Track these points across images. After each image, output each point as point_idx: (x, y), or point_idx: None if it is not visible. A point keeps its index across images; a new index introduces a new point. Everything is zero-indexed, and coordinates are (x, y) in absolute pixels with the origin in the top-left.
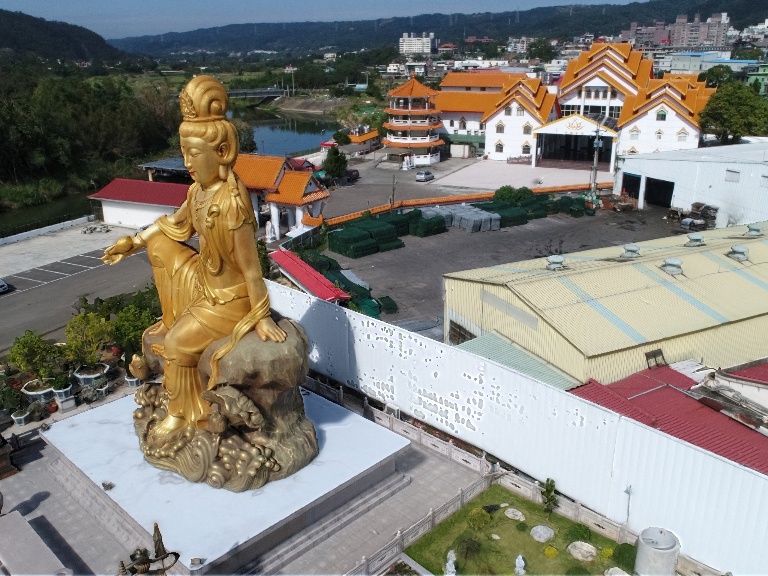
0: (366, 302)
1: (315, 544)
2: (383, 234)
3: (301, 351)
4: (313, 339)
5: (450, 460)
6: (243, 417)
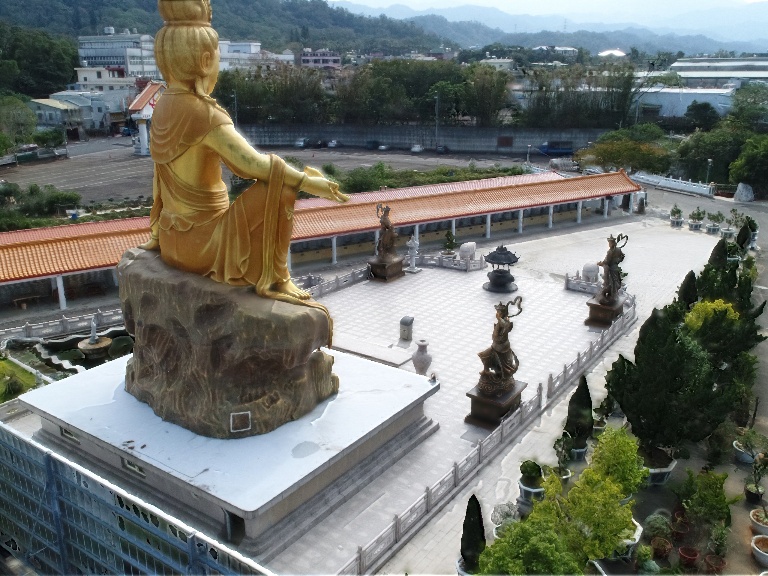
0: None
1: None
2: None
3: None
4: None
5: None
6: None
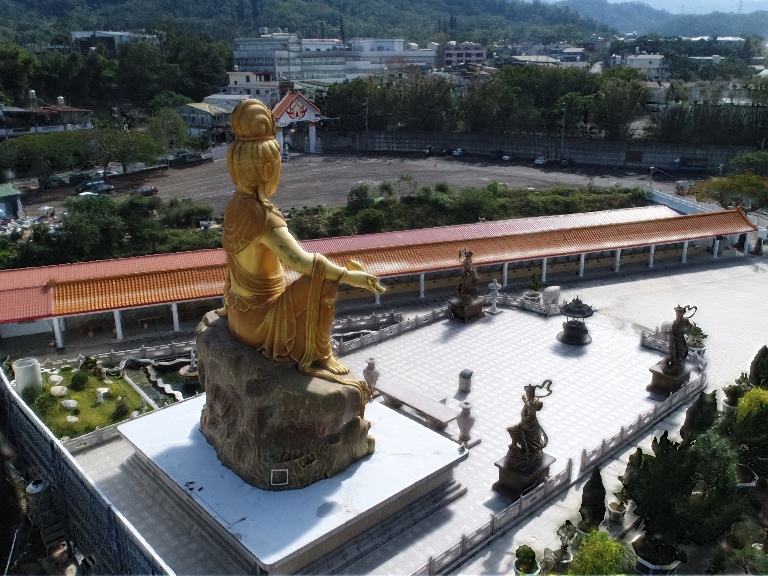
0: None
1: None
2: None
3: None
4: None
5: None
6: None
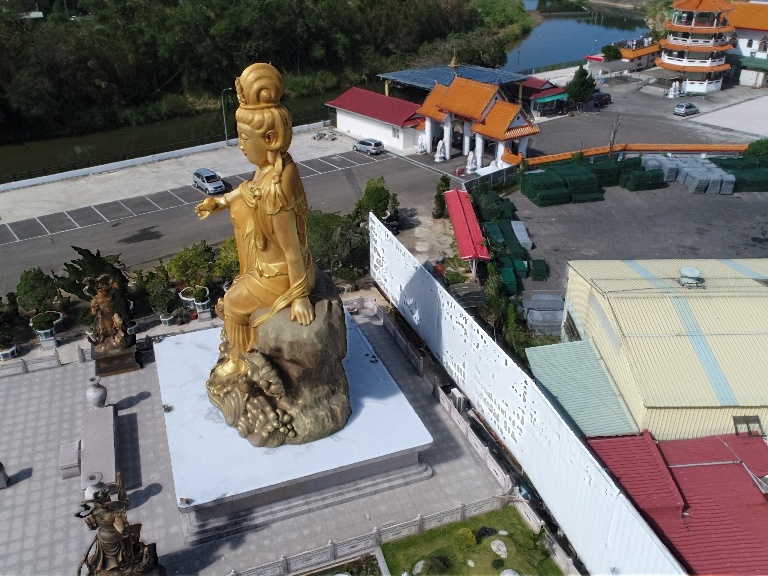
0: (516, 263)
1: (311, 510)
2: (581, 183)
3: (322, 337)
4: (416, 303)
5: (484, 465)
6: (262, 385)
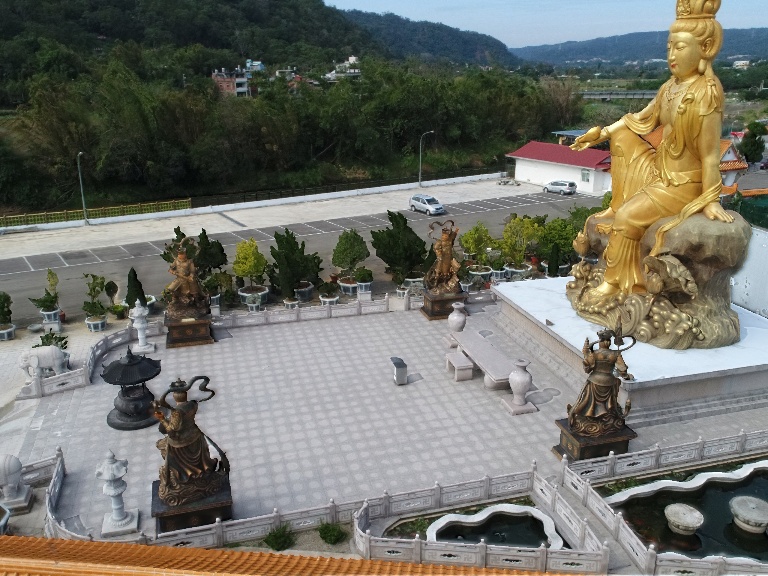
0: None
1: (728, 411)
2: None
3: (747, 234)
4: None
5: None
6: (681, 281)
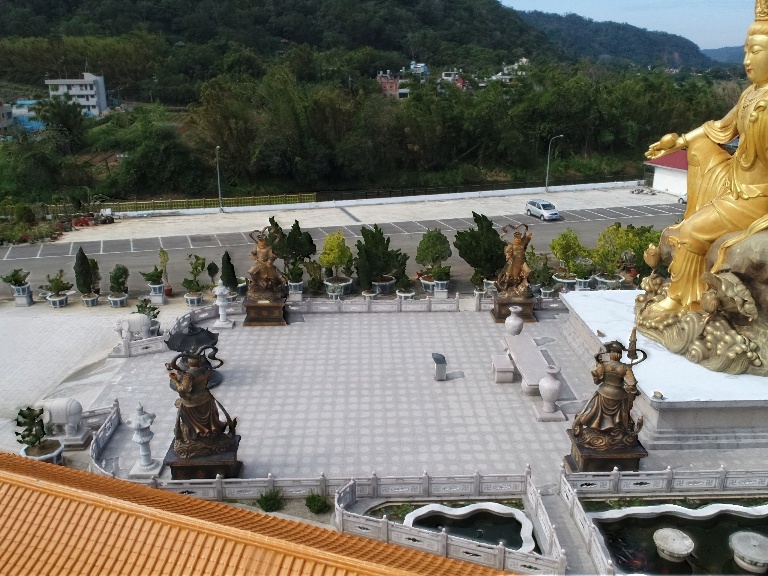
0: None
1: None
2: None
3: None
4: None
5: None
6: (737, 301)
